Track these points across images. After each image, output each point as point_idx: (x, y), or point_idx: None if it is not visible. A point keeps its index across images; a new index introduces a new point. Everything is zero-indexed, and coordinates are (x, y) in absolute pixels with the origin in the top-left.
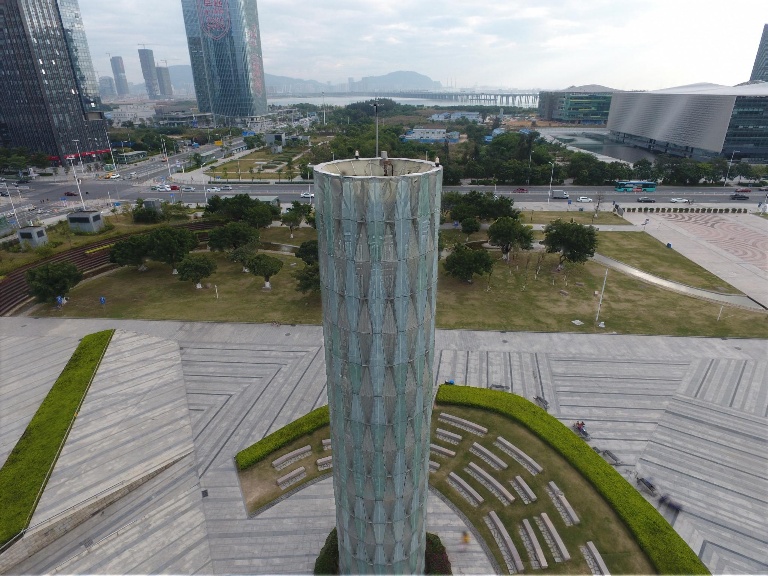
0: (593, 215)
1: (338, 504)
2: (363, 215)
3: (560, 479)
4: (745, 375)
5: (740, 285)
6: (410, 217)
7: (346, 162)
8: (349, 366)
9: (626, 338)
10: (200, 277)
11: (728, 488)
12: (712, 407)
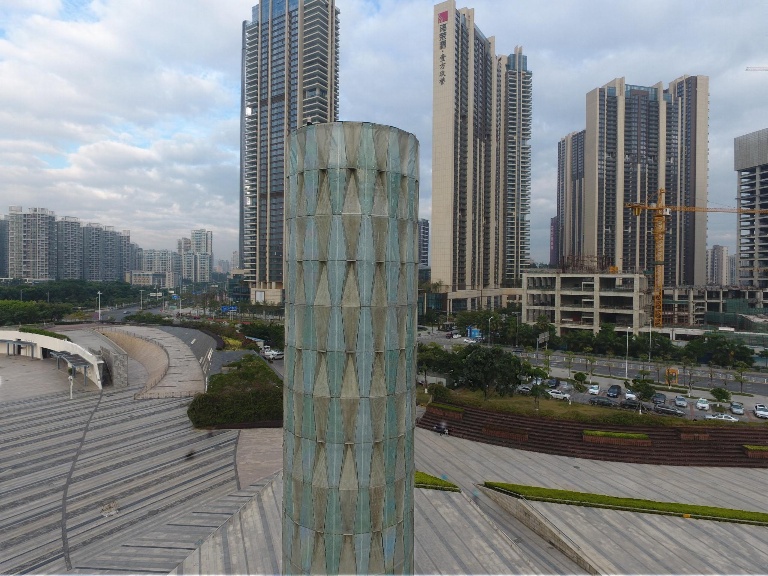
0: None
1: None
2: None
3: None
4: None
5: None
6: None
7: None
8: None
9: None
10: None
11: None
12: None
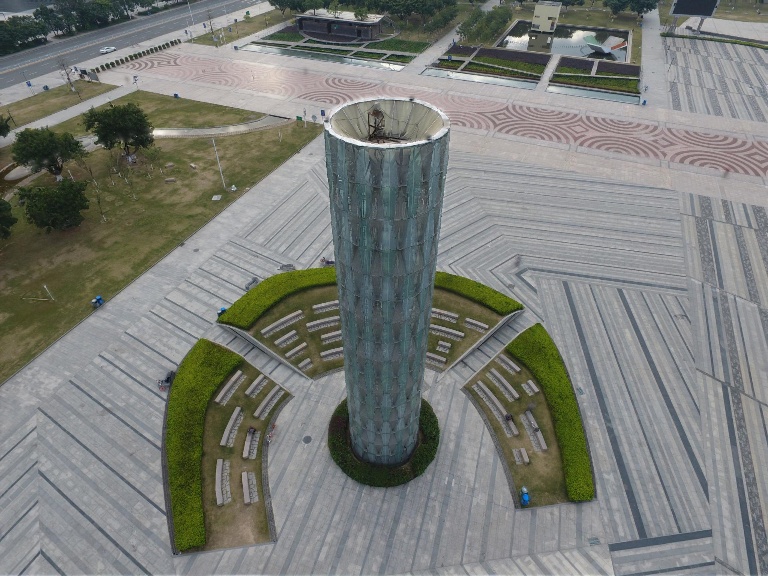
0: (70, 90)
1: (391, 410)
2: None
3: None
4: None
5: (257, 108)
6: None
7: None
8: (420, 295)
9: (258, 188)
10: None
11: None
12: None
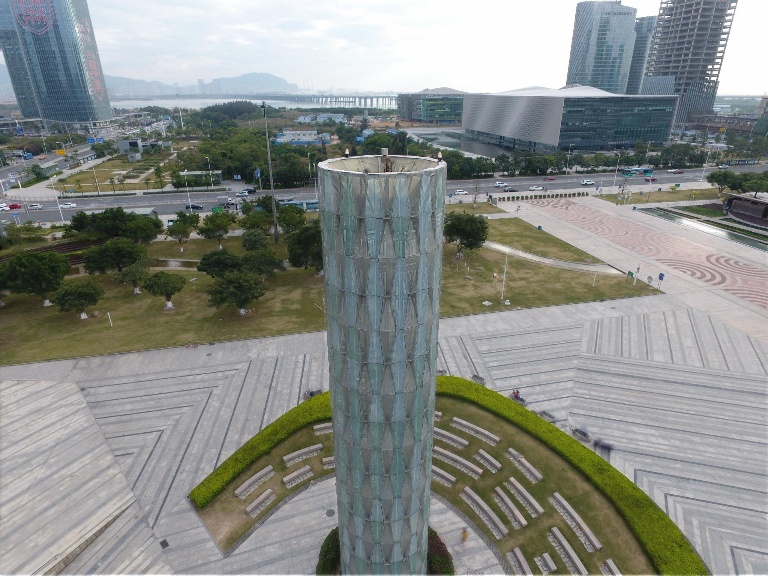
0: (472, 206)
1: (348, 513)
2: (387, 212)
3: (516, 444)
4: (624, 329)
5: (600, 256)
6: (431, 211)
7: (338, 161)
8: (369, 367)
9: (529, 311)
10: (86, 305)
11: (639, 423)
12: (609, 359)
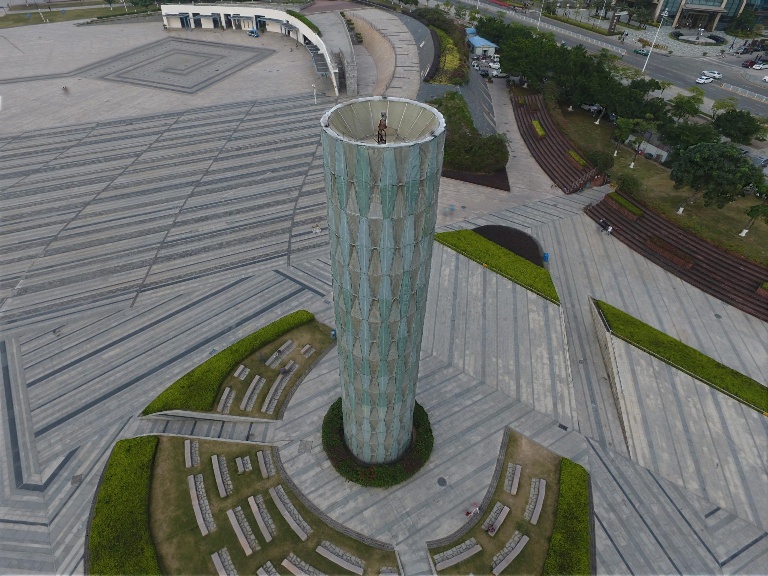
0: None
1: None
2: None
3: None
4: None
5: None
6: None
7: None
8: None
9: None
10: None
11: None
12: None
